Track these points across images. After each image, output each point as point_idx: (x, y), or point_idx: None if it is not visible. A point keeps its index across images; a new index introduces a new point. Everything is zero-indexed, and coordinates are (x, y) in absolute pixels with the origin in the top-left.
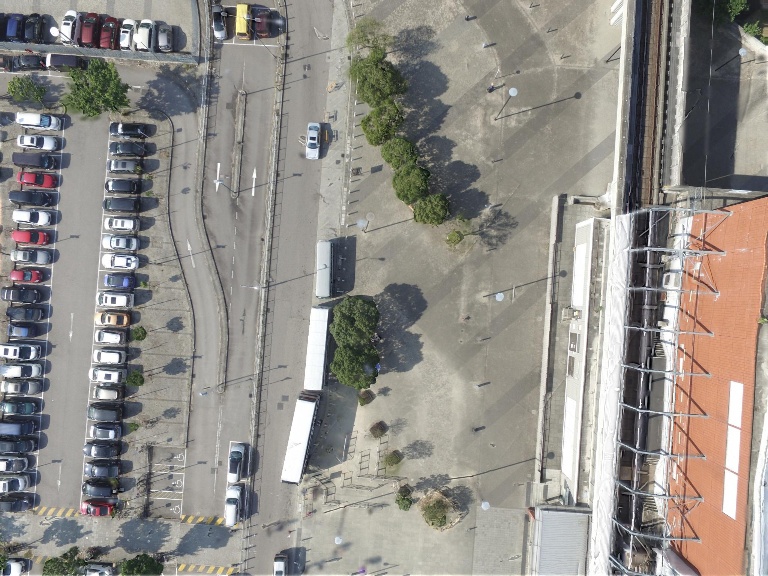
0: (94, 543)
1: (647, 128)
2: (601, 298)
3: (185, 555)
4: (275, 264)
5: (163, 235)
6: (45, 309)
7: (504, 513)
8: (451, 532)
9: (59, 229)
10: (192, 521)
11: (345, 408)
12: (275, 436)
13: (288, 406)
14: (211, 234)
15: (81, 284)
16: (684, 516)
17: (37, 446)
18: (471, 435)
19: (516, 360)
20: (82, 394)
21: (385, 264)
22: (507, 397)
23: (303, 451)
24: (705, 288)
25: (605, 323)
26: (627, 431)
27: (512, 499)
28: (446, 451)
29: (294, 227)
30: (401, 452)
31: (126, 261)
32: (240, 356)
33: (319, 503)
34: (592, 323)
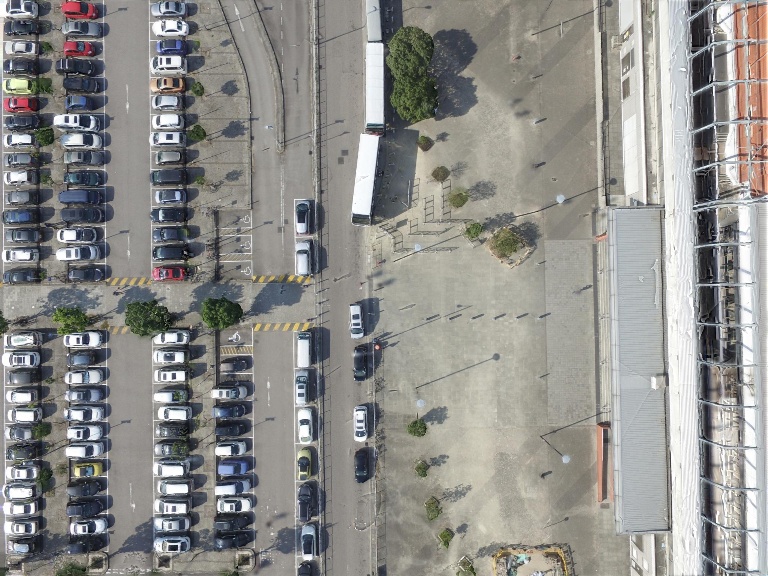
0: (169, 309)
1: None
2: (652, 4)
3: (260, 314)
4: (323, 21)
5: (210, 1)
6: (100, 83)
7: (572, 245)
8: (521, 268)
9: (107, 3)
10: (264, 280)
11: (405, 157)
12: (338, 190)
13: (348, 160)
14: None
15: (133, 56)
16: (764, 156)
17: (104, 217)
18: (532, 172)
19: (570, 94)
20: (144, 164)
21: (432, 12)
22: (564, 131)
23: (371, 184)
24: None
25: (661, 17)
26: None
27: (578, 230)
28: (509, 190)
29: None
30: (464, 195)
31: (177, 24)
32: (296, 115)
33: (388, 252)
34: (646, 27)
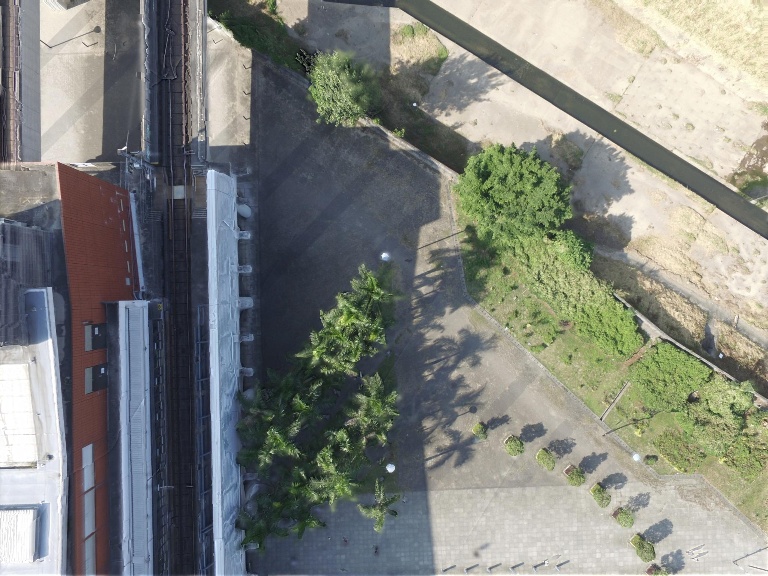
0: None
1: (12, 111)
2: None
3: None
4: None
5: None
6: None
7: None
8: None
9: None
10: None
11: None
12: None
13: None
14: None
15: None
16: None
17: None
18: None
19: None
20: None
21: None
22: None
23: None
24: None
25: None
26: None
27: None
28: None
29: None
30: None
31: None
32: None
33: None
34: None
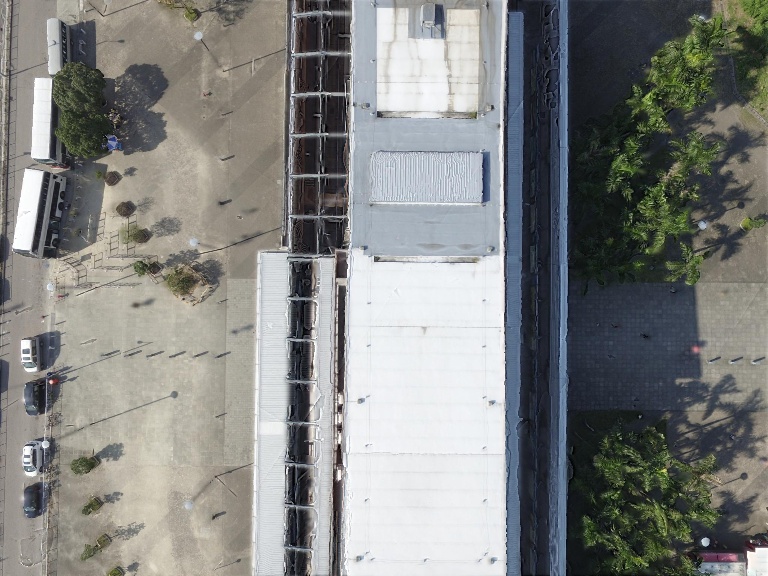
0: None
1: None
2: None
3: None
4: (15, 53)
5: None
6: None
7: (254, 284)
8: (203, 306)
9: None
10: None
11: (92, 191)
12: None
13: None
14: None
15: None
16: None
17: None
18: (218, 209)
19: (259, 132)
20: None
21: (125, 46)
22: (252, 169)
23: (33, 219)
24: None
25: None
26: (331, 159)
27: None
28: (194, 226)
29: (33, 15)
30: (150, 230)
31: None
32: None
33: (71, 286)
34: None
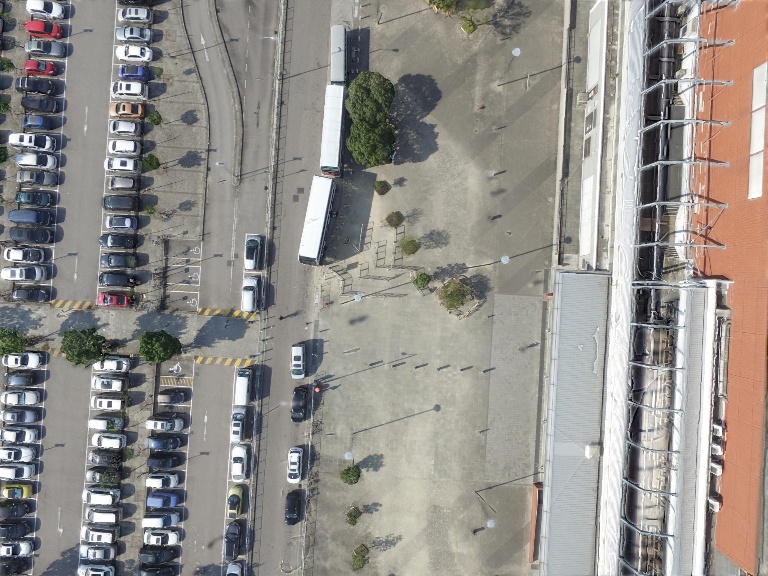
0: (111, 335)
1: None
2: (617, 67)
3: (202, 347)
4: (289, 57)
5: (176, 28)
6: (59, 103)
7: (522, 301)
8: (469, 321)
9: (73, 23)
10: (209, 313)
11: (361, 199)
12: (291, 228)
13: (304, 198)
14: (224, 28)
15: (95, 78)
16: (707, 237)
17: (53, 239)
18: (487, 224)
19: (532, 148)
20: (97, 187)
21: (399, 55)
22: (523, 185)
23: (320, 227)
24: (724, 9)
25: (622, 82)
26: (646, 183)
27: (530, 286)
28: (463, 240)
29: (307, 20)
30: (417, 242)
31: (140, 50)
32: (255, 149)
33: (336, 294)
34: (608, 90)
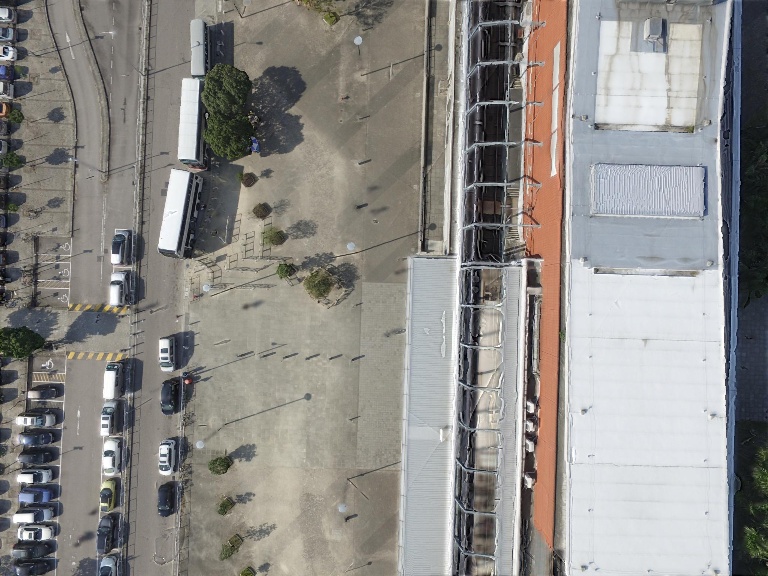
0: None
1: None
2: None
3: (74, 343)
4: (154, 52)
5: (41, 27)
6: None
7: (389, 288)
8: (338, 309)
9: None
10: (80, 309)
11: (228, 192)
12: (160, 222)
13: None
14: (89, 25)
15: None
16: (532, 217)
17: None
18: (354, 213)
19: (396, 136)
20: None
21: (263, 48)
22: (388, 173)
23: (179, 219)
24: None
25: None
26: (489, 167)
27: (397, 274)
28: (330, 230)
29: (171, 15)
30: (285, 233)
31: (3, 49)
32: (122, 145)
33: None
34: (458, 76)
